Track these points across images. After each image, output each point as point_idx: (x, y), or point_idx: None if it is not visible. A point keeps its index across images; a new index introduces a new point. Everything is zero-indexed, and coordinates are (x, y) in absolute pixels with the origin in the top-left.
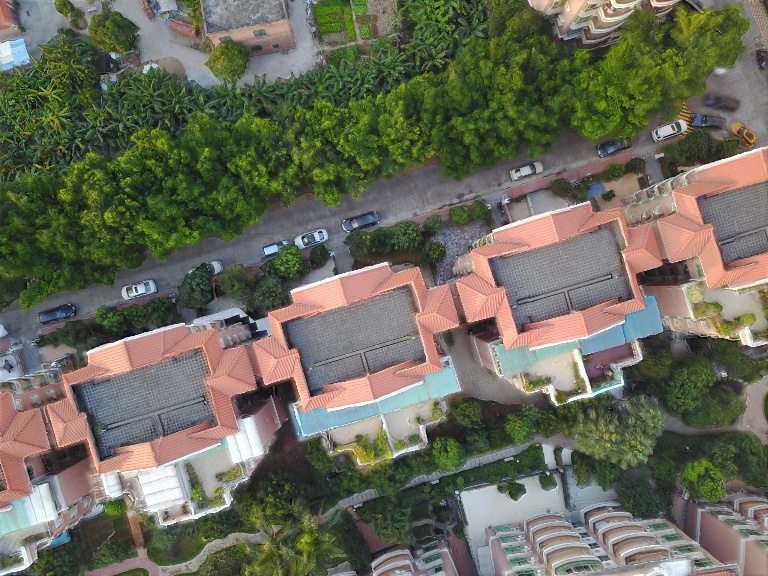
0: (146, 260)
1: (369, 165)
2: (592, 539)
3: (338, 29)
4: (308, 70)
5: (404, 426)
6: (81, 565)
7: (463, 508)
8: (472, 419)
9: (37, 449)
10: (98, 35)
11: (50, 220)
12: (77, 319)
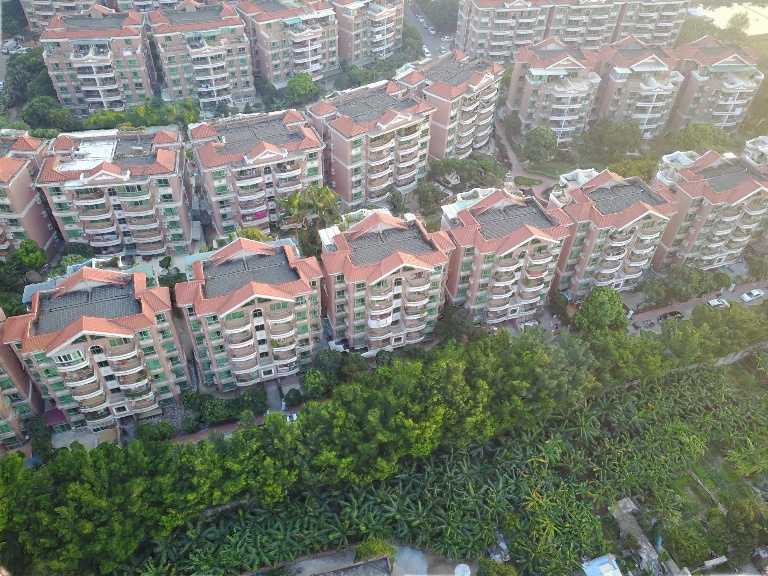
0: None
1: (234, 435)
2: (121, 228)
3: None
4: None
5: None
6: None
7: None
8: None
9: None
10: (505, 568)
11: (496, 377)
12: None
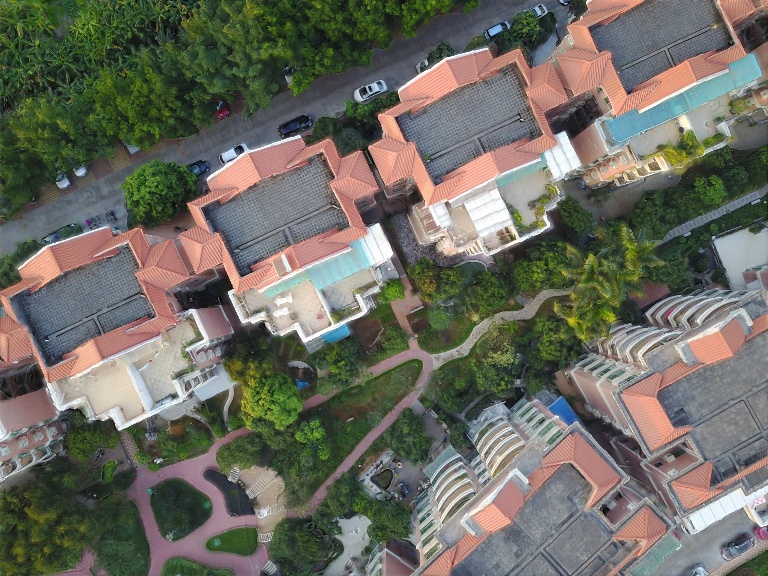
0: (372, 62)
1: None
2: None
3: None
4: None
5: (702, 131)
6: (360, 361)
7: (718, 255)
8: (725, 157)
9: (368, 188)
10: None
11: None
12: None
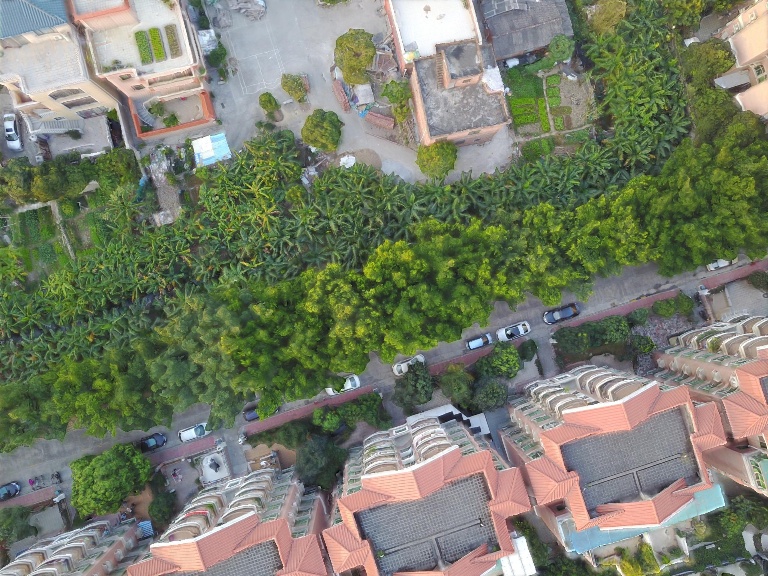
0: None
1: (596, 268)
2: None
3: (533, 121)
4: (513, 165)
5: (661, 537)
6: None
7: None
8: None
9: None
10: (313, 135)
11: None
12: (280, 415)
